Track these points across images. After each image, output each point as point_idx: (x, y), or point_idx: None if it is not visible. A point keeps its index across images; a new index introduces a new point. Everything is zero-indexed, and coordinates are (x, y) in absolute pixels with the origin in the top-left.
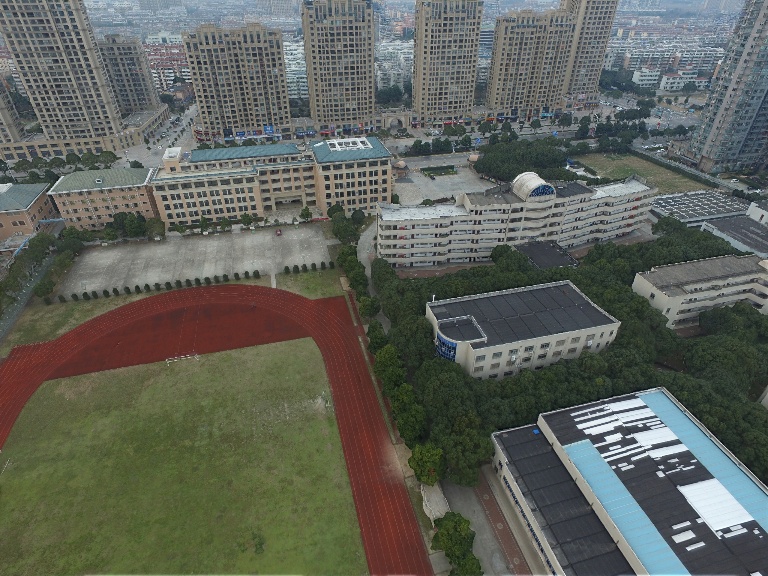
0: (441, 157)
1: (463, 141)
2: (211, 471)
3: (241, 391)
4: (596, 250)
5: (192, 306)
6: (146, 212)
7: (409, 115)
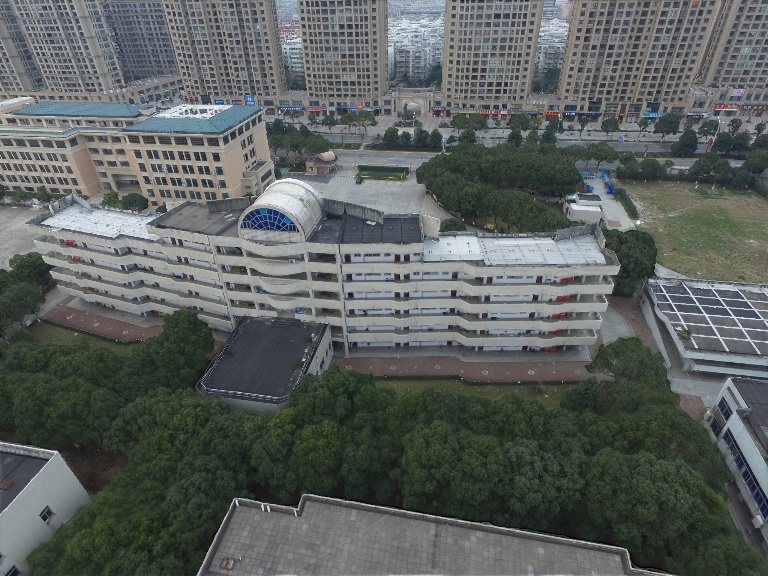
0: (417, 155)
1: (460, 136)
2: None
3: None
4: None
5: None
6: None
7: (429, 97)
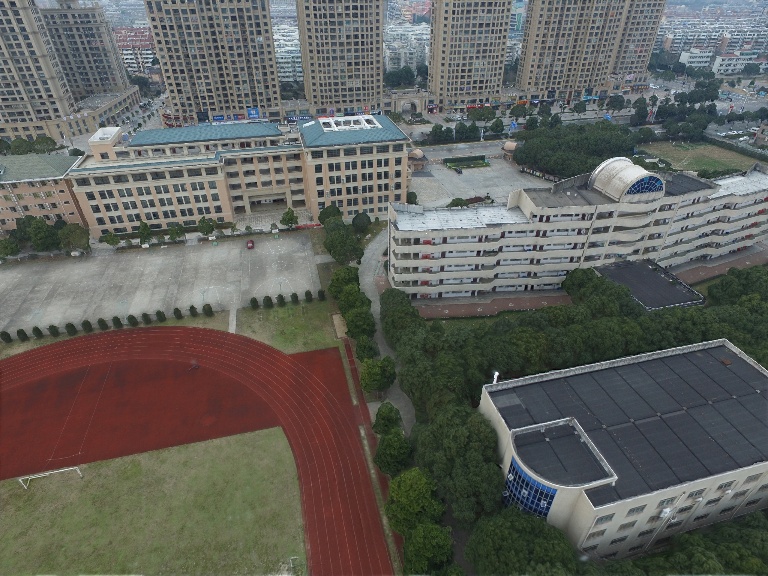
0: (466, 146)
1: (494, 126)
2: None
3: (141, 551)
4: (735, 279)
5: (99, 365)
6: (70, 215)
7: (425, 97)
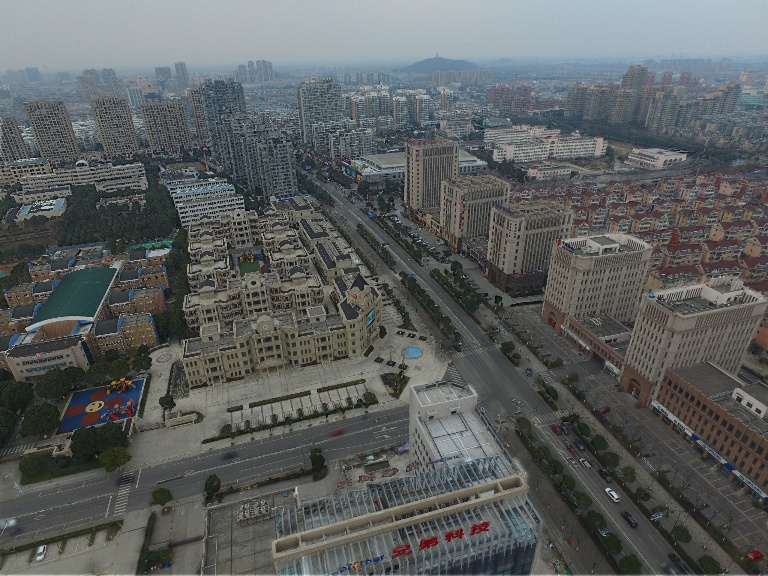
0: None
1: None
2: None
3: None
4: None
5: None
6: None
7: (100, 153)
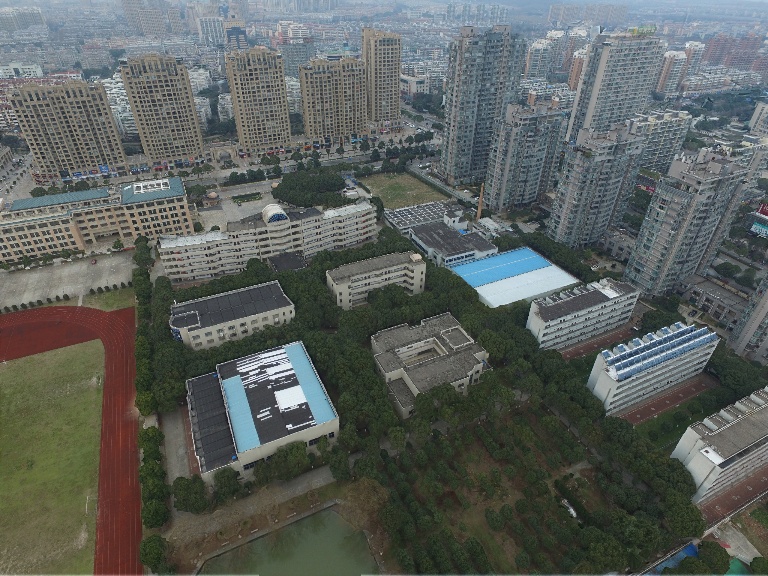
0: (255, 185)
1: (273, 170)
2: (4, 431)
3: (37, 381)
4: (316, 256)
5: (8, 327)
6: None
7: (235, 148)
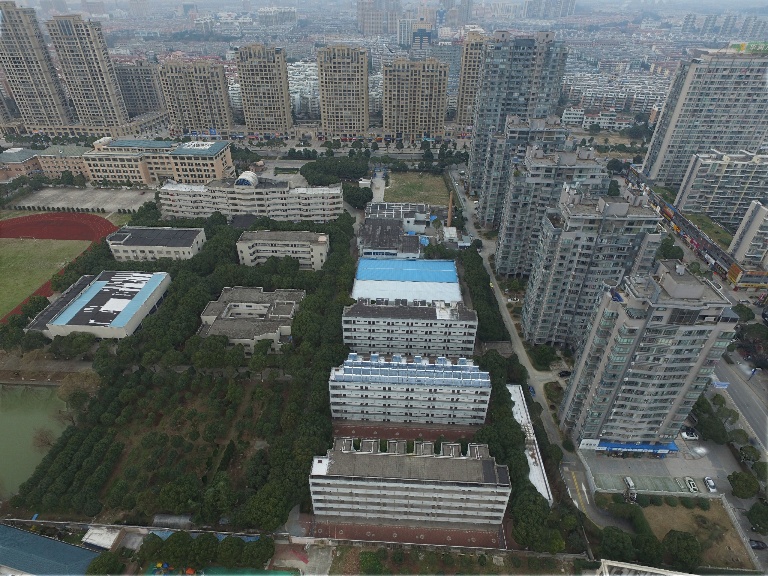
0: (305, 162)
1: (326, 152)
2: None
3: (38, 254)
4: None
5: (60, 220)
6: (85, 173)
7: (315, 130)
